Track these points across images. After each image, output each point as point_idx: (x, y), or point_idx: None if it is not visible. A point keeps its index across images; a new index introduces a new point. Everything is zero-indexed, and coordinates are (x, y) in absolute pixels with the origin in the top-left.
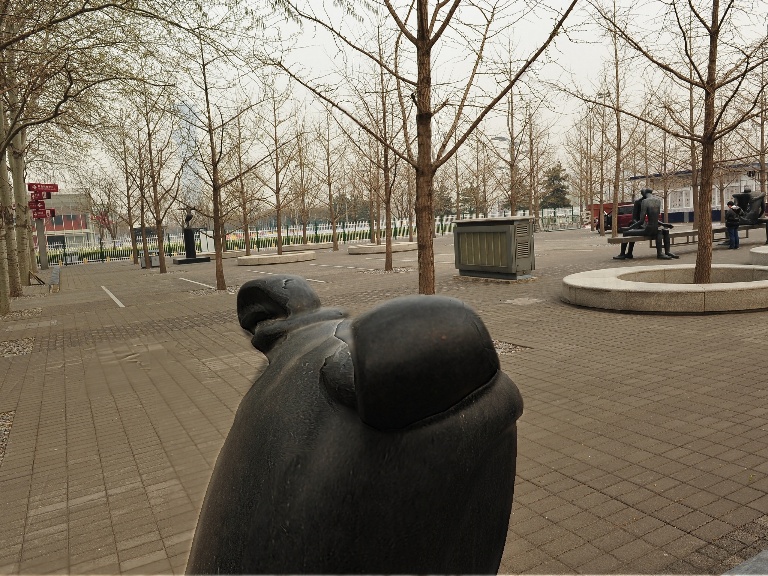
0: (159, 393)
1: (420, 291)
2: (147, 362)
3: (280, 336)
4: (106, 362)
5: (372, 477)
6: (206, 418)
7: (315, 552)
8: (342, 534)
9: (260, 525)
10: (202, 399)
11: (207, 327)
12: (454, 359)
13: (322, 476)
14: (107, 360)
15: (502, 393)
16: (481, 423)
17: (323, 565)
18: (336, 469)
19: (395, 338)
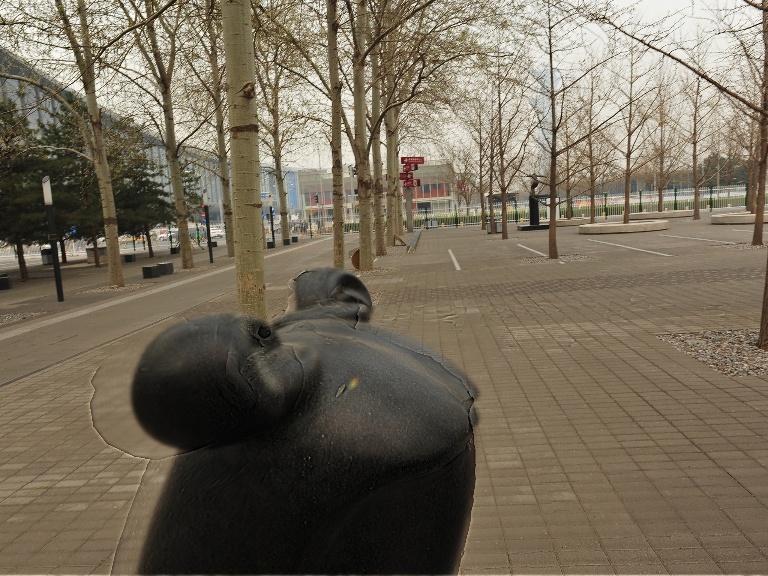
0: (461, 354)
1: (767, 274)
2: (461, 324)
3: (267, 330)
4: (428, 319)
5: (191, 501)
6: (493, 385)
7: (139, 559)
8: (157, 551)
9: (130, 516)
10: (496, 366)
11: (525, 295)
12: (153, 396)
13: (164, 486)
14: (429, 318)
15: (401, 439)
16: (336, 471)
17: (141, 575)
18: (175, 482)
19: (118, 361)
